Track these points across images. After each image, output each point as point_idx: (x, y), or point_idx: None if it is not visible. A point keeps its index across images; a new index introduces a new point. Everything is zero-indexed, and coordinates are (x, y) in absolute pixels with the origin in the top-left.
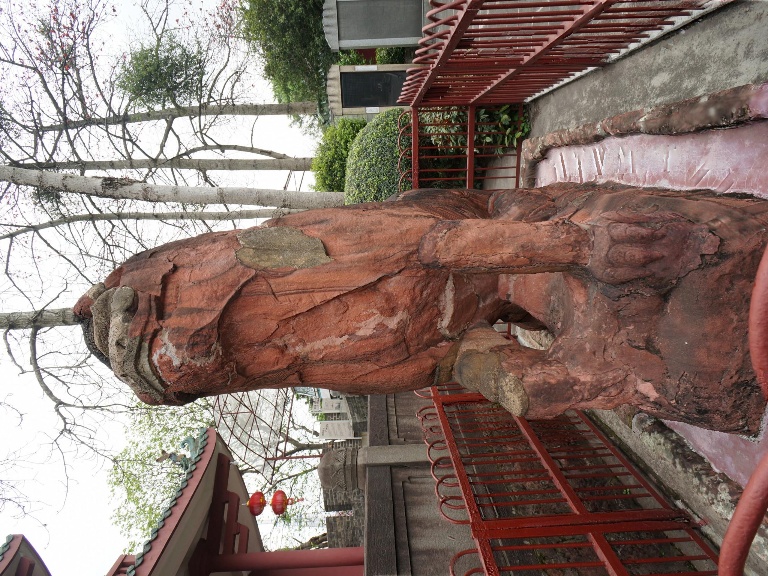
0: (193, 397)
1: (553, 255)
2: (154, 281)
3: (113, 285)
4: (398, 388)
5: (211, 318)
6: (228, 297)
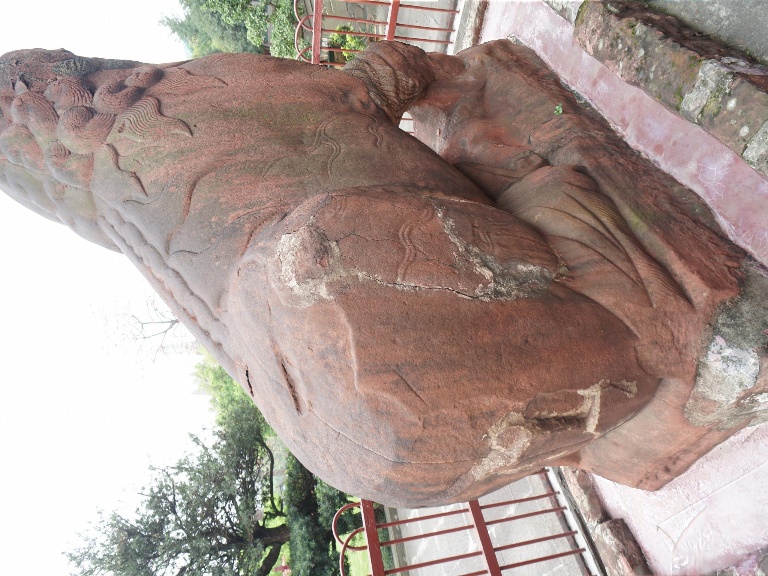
0: None
1: None
2: None
3: None
4: None
5: None
6: None
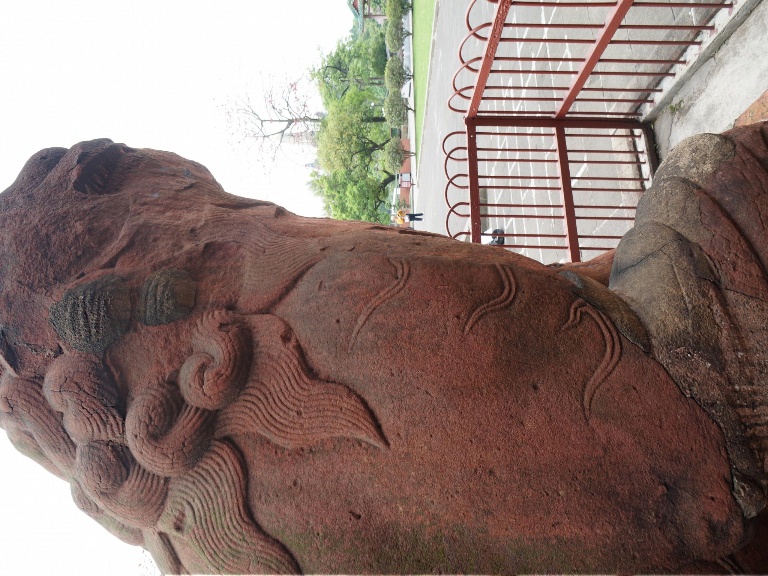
0: (91, 176)
1: (605, 255)
2: None
3: None
4: (475, 249)
5: None
6: None
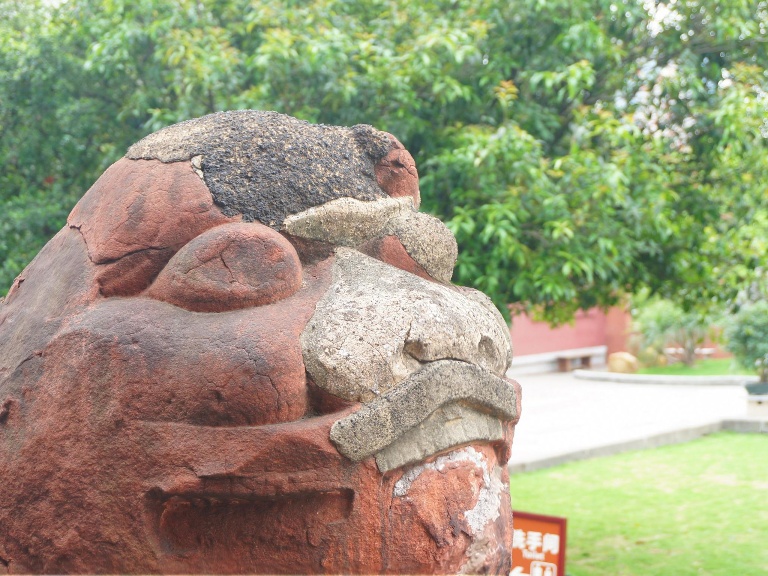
0: None
1: None
2: None
3: None
4: None
5: None
6: None
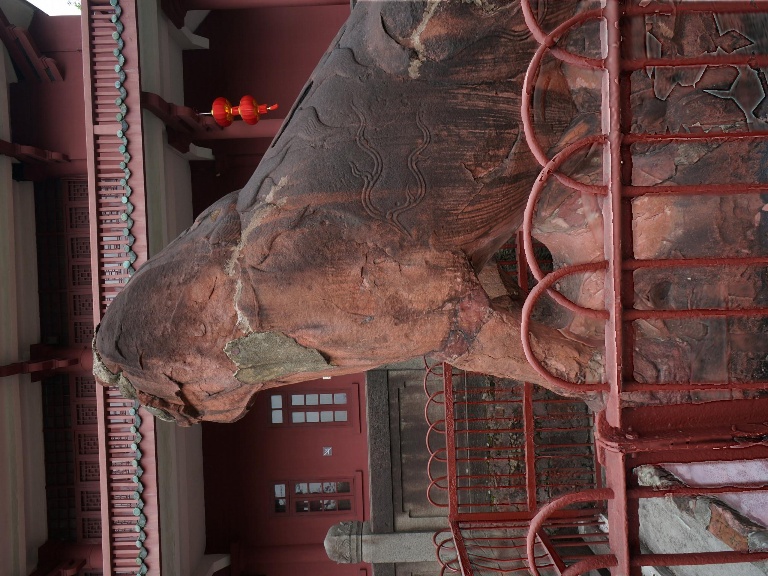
0: None
1: None
2: (169, 394)
3: (118, 370)
4: None
5: (240, 412)
6: (246, 400)
